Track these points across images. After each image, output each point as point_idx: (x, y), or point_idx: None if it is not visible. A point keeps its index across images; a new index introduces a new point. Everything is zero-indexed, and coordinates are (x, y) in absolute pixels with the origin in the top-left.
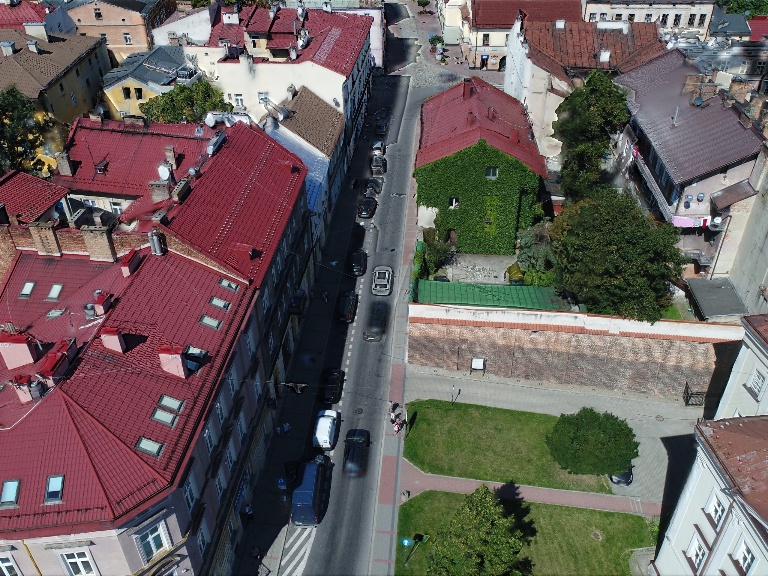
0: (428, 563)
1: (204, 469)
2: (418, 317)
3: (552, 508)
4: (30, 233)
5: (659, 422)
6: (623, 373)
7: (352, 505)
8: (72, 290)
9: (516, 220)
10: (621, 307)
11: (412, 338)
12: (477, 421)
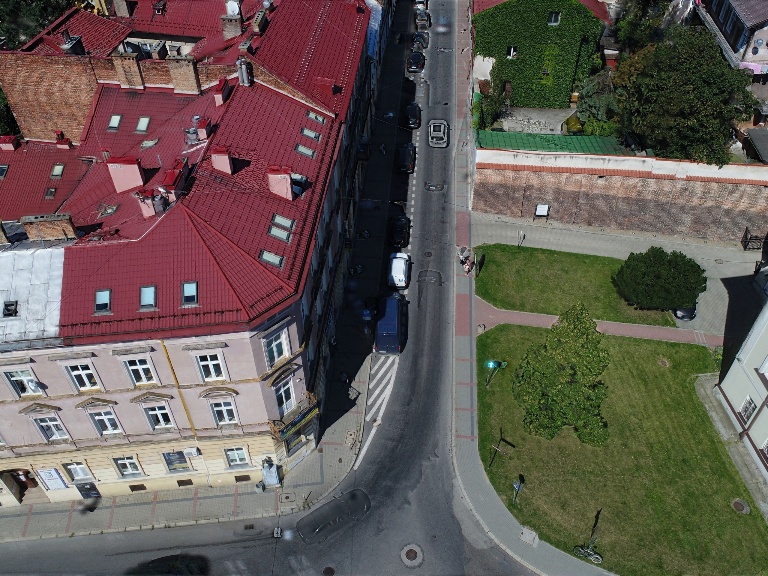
0: (517, 379)
1: (310, 289)
2: (485, 163)
3: (621, 339)
4: (112, 64)
5: (719, 265)
6: (685, 218)
7: (431, 337)
8: (160, 122)
9: (574, 71)
10: (691, 150)
11: (478, 185)
12: (544, 263)
